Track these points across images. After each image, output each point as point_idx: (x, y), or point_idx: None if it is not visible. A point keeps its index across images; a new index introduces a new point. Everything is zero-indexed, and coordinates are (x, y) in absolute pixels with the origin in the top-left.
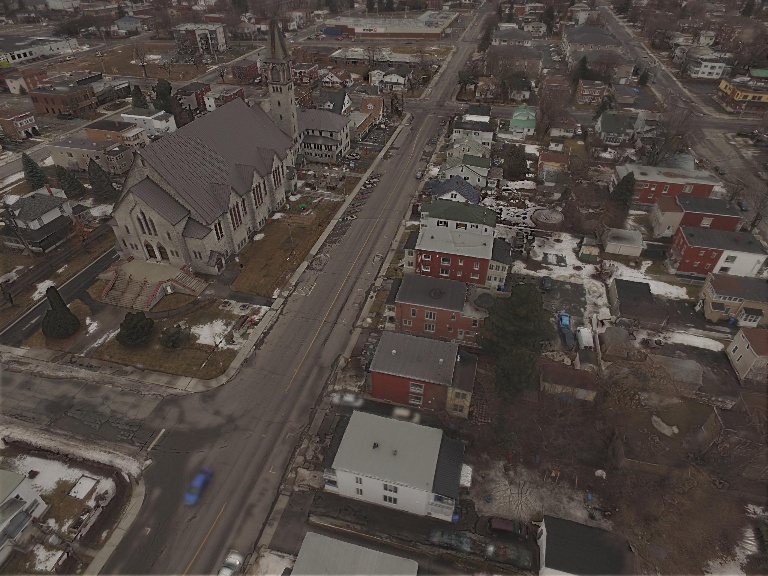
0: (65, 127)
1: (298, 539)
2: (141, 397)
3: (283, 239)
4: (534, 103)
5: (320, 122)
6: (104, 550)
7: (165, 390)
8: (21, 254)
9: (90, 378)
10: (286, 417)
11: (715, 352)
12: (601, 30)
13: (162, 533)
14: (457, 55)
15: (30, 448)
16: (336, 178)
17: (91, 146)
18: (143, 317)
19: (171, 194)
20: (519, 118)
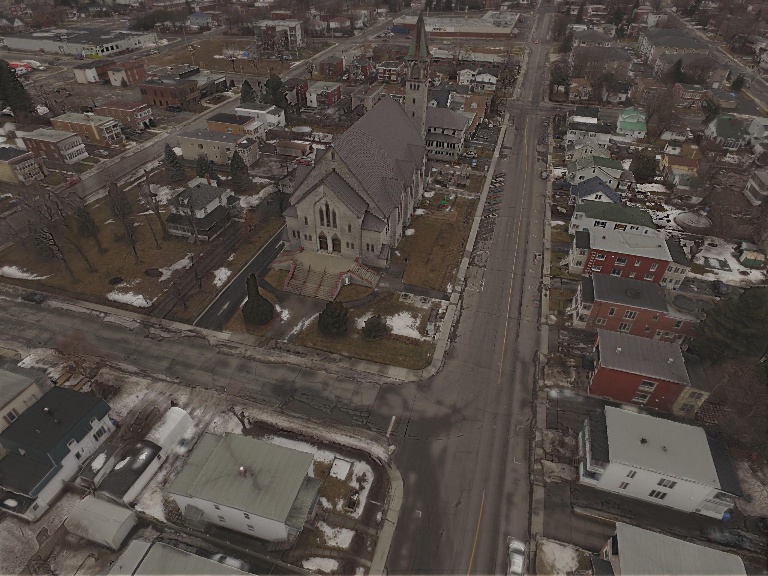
0: (176, 119)
1: (571, 529)
2: (359, 384)
3: (435, 235)
4: (630, 106)
5: (443, 120)
6: (385, 530)
7: (379, 378)
8: (187, 241)
9: (302, 364)
10: (509, 409)
11: None
12: (682, 33)
13: (434, 516)
14: (533, 56)
15: (273, 429)
16: (462, 176)
17: (222, 138)
18: (342, 306)
19: (354, 187)
20: (629, 120)
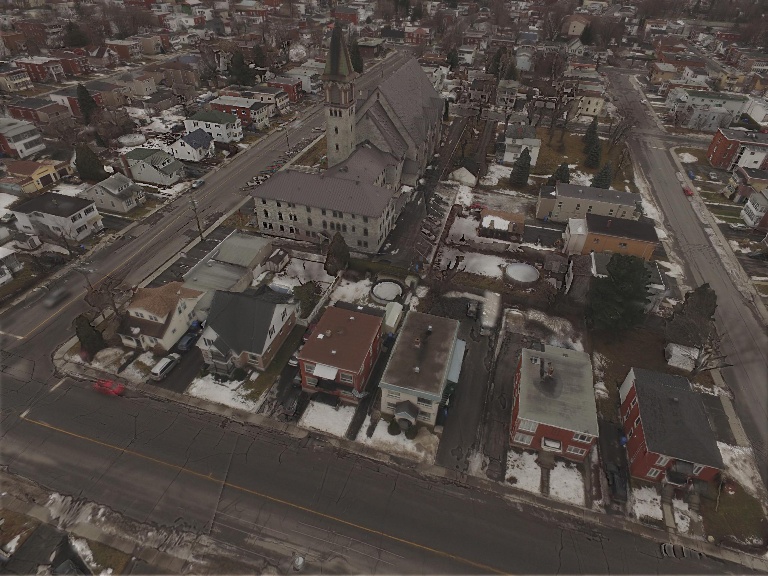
0: None
1: None
2: None
3: None
4: None
5: None
6: None
7: None
8: None
9: None
10: None
11: (151, 96)
12: None
13: None
14: None
15: None
16: None
17: None
18: None
19: None
20: None
